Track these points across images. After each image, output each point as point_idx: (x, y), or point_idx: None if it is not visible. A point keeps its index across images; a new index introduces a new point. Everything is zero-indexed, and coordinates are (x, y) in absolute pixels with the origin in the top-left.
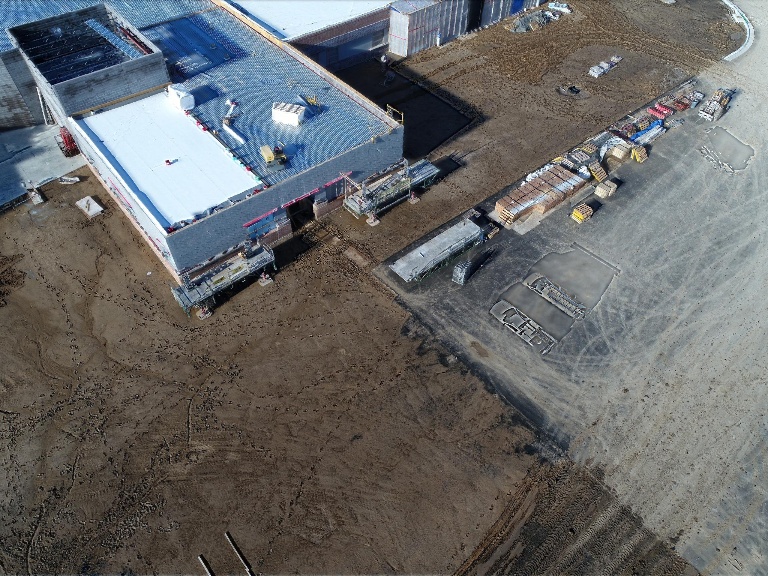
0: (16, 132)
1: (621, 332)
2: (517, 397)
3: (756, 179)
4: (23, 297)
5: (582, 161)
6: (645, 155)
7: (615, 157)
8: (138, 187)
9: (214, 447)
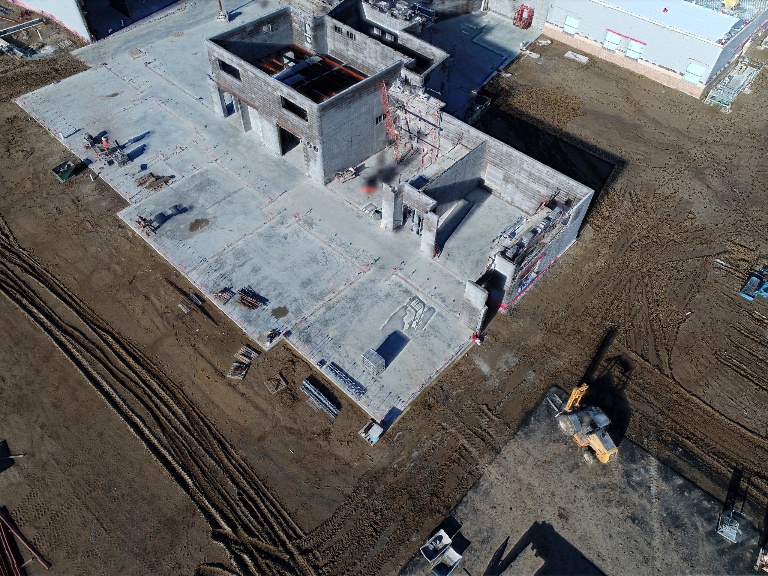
0: (464, 16)
1: None
2: None
3: None
4: (592, 110)
5: None
6: None
7: None
8: None
9: None
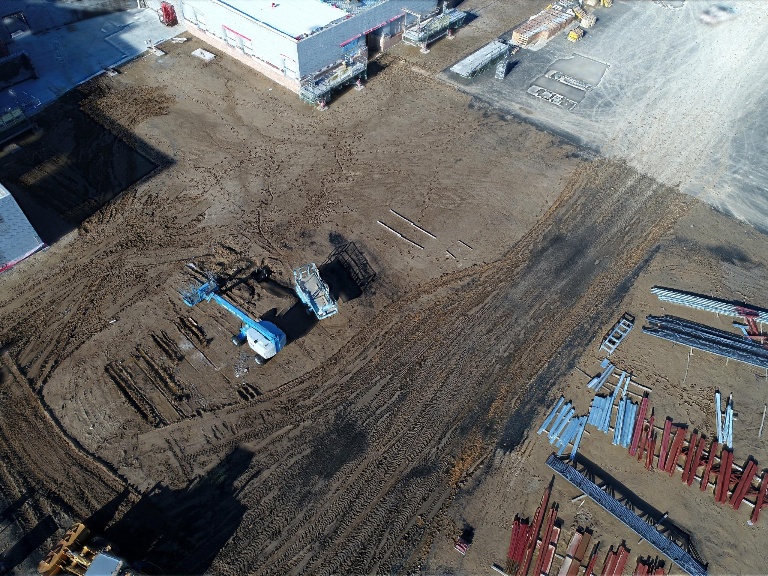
0: (116, 14)
1: (619, 96)
2: (559, 131)
3: (691, 12)
4: (180, 109)
5: (567, 5)
6: (611, 2)
7: (589, 5)
8: (259, 20)
9: (363, 173)
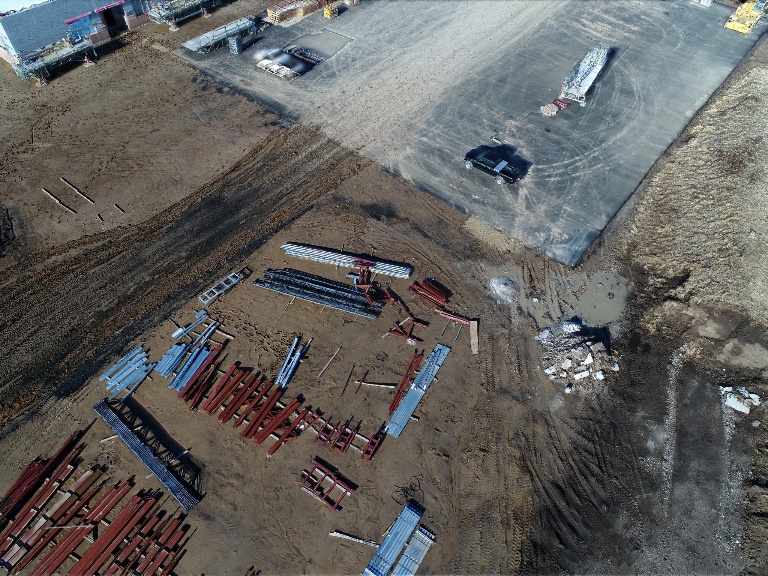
0: None
1: (347, 67)
2: (269, 101)
3: None
4: None
5: None
6: None
7: None
8: None
9: (52, 144)
